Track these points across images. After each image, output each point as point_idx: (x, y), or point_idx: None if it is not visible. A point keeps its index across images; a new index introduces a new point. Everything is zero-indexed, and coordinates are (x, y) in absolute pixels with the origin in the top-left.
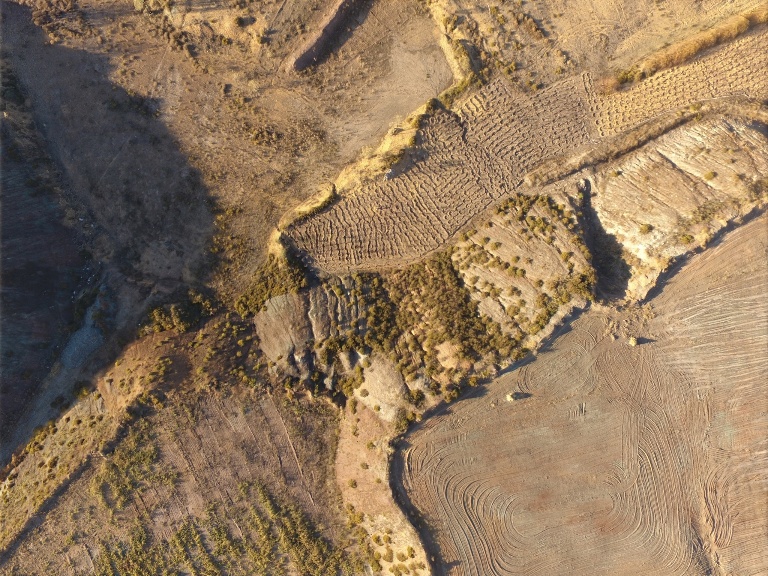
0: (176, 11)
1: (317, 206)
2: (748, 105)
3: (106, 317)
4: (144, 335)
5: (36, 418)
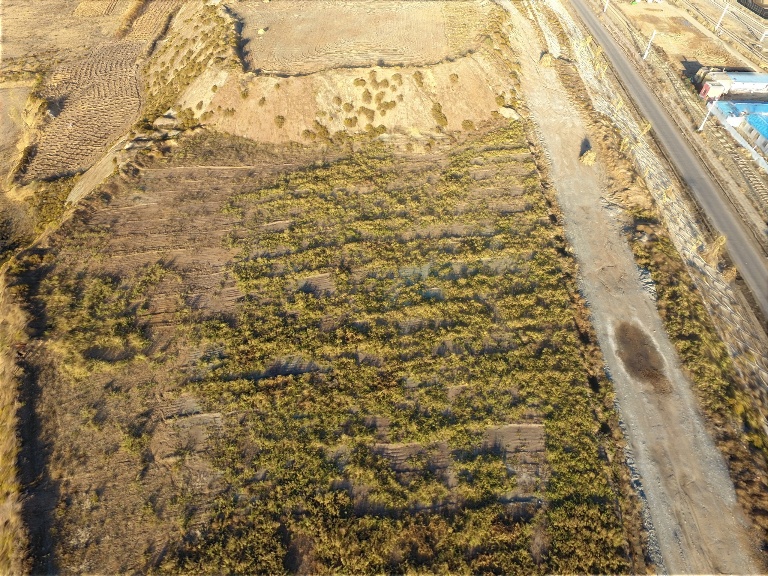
0: None
1: None
2: (184, 2)
3: None
4: None
5: None
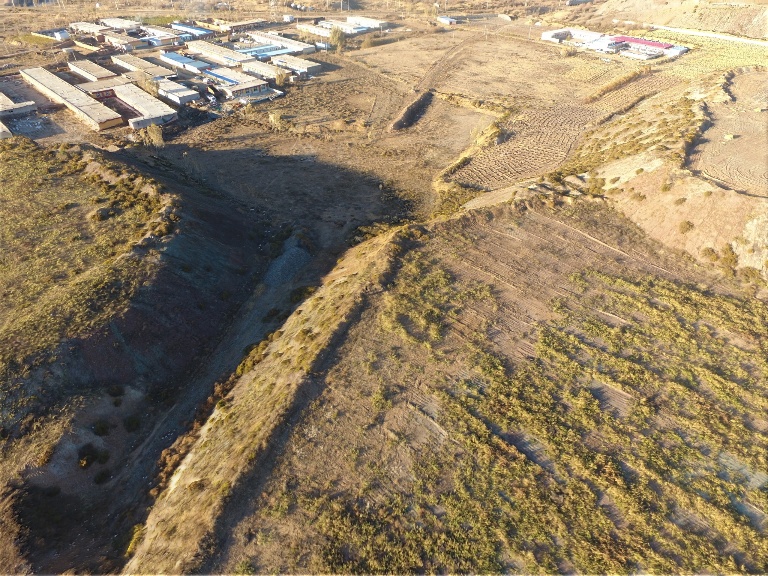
0: (299, 126)
1: (458, 162)
2: None
3: (309, 239)
4: (356, 243)
5: (242, 341)
